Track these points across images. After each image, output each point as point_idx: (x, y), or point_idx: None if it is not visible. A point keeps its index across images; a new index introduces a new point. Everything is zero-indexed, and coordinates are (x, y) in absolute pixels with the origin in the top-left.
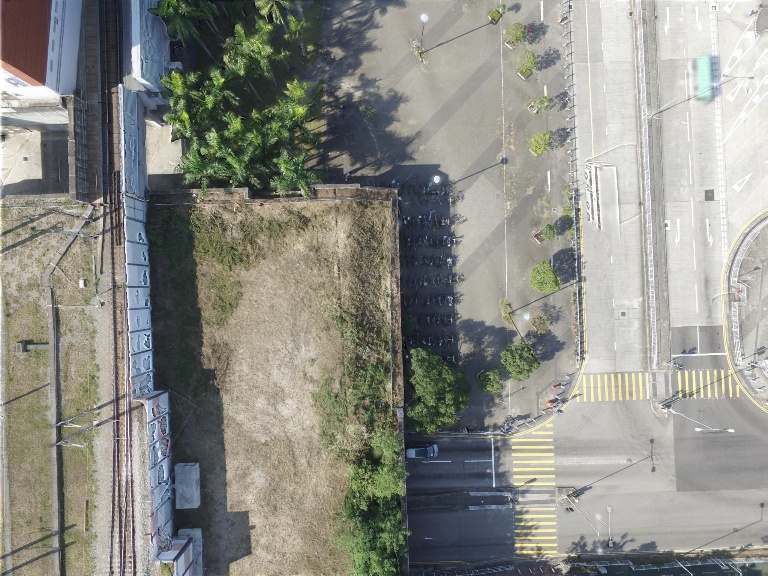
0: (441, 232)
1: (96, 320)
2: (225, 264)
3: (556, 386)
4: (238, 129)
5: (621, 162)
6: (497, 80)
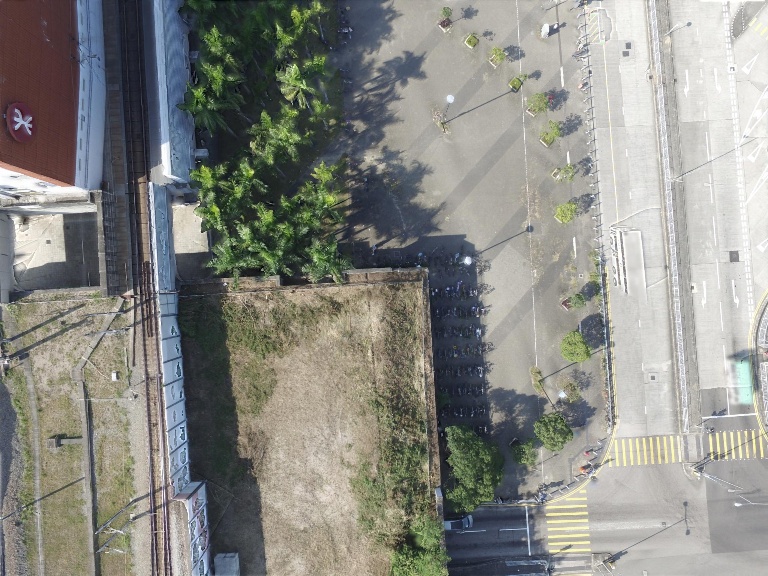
0: (469, 302)
1: (129, 412)
2: (258, 352)
3: (588, 452)
4: (270, 221)
5: (646, 226)
6: (520, 148)
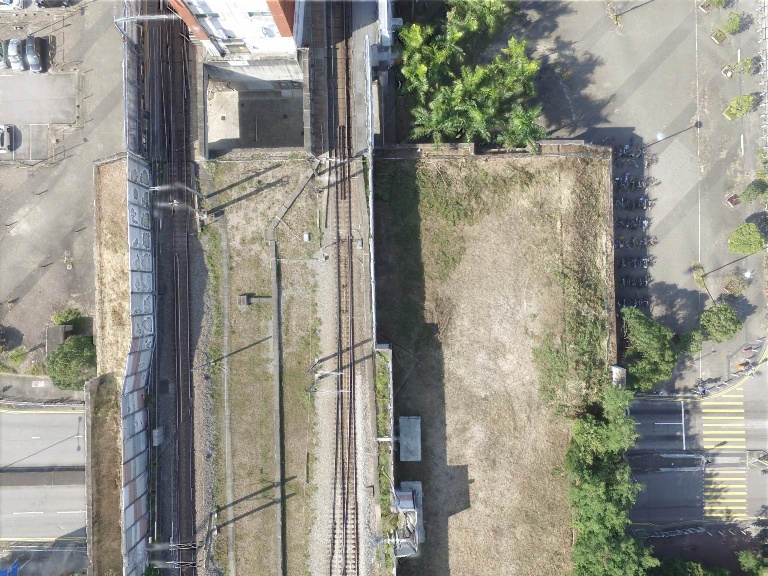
0: (635, 195)
1: (318, 274)
2: (449, 219)
3: (747, 350)
4: (477, 82)
5: None
6: (691, 44)
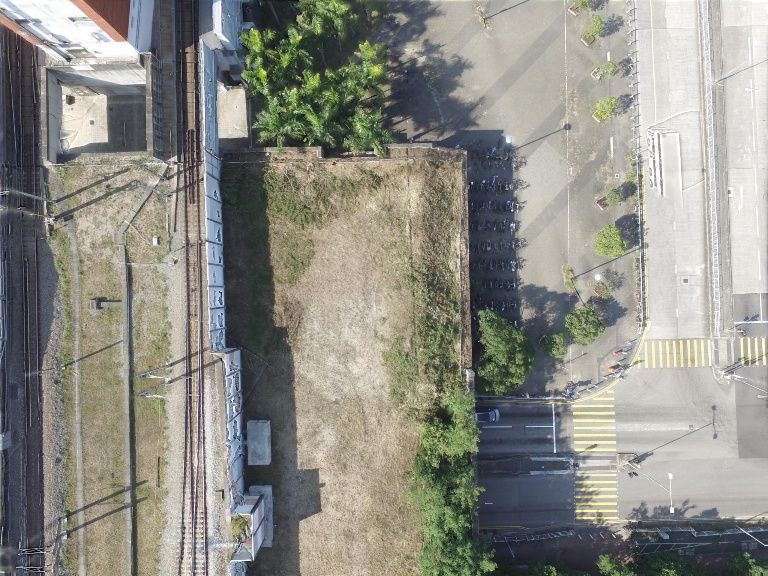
0: (504, 197)
1: (169, 278)
2: (298, 223)
3: (617, 352)
4: (315, 86)
5: (684, 129)
6: (560, 46)
